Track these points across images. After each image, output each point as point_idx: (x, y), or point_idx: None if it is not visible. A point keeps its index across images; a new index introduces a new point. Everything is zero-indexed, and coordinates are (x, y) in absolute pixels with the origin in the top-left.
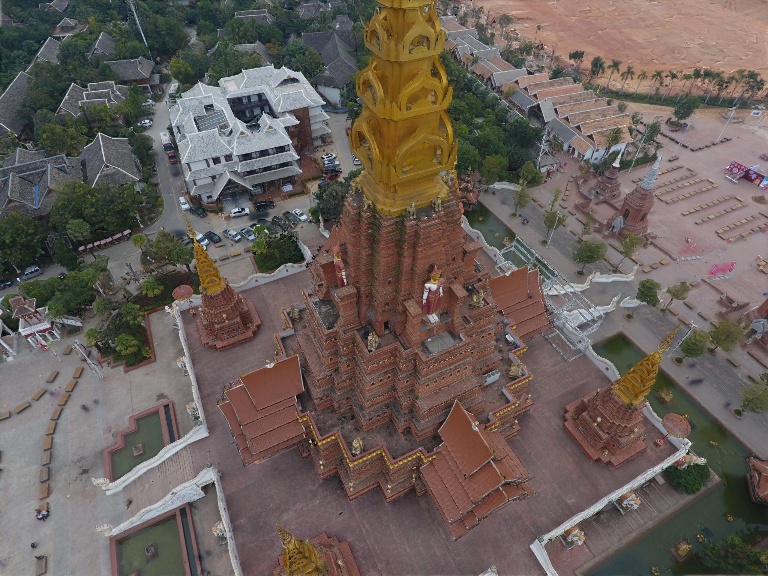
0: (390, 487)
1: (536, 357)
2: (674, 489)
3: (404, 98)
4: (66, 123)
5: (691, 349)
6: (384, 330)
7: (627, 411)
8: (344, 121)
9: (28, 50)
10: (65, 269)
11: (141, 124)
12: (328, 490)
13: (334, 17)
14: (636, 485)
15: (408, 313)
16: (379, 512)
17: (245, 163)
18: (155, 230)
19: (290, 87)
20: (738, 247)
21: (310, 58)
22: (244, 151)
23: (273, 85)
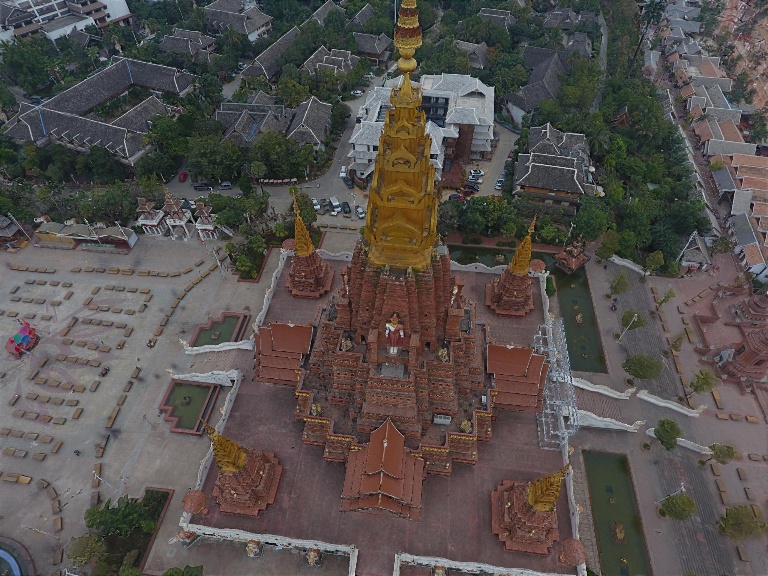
0: (327, 450)
1: (515, 428)
2: None
3: (385, 194)
4: (301, 78)
5: (670, 508)
6: (361, 341)
7: (529, 511)
8: None
9: (313, 6)
10: (242, 192)
11: (354, 93)
12: (295, 428)
13: (574, 32)
14: (517, 575)
15: None
16: (316, 463)
17: None
18: (313, 185)
19: (474, 100)
20: None
21: (514, 74)
22: None
23: (461, 94)
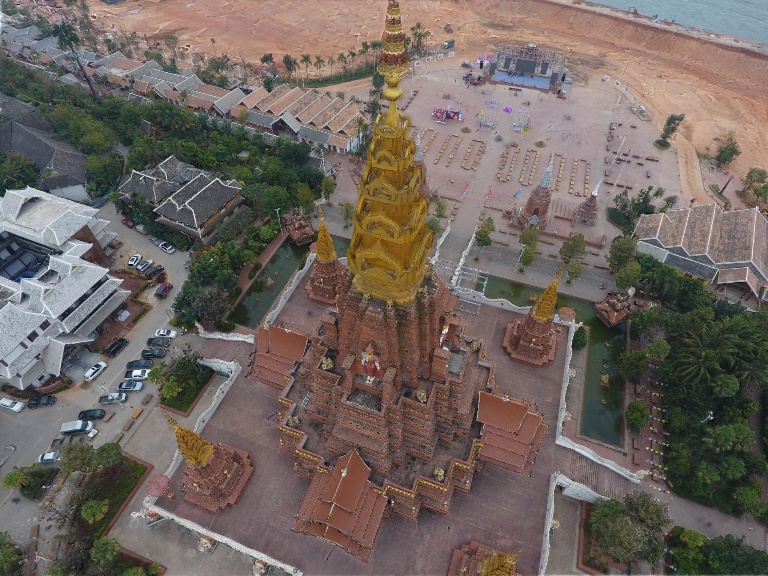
0: None
1: None
2: (577, 350)
3: (416, 223)
4: None
5: (528, 261)
6: None
7: (547, 325)
8: (110, 214)
9: None
10: None
11: None
12: (426, 522)
13: None
14: None
15: (436, 359)
16: (468, 504)
17: (68, 319)
18: (4, 455)
19: None
20: (480, 171)
21: (16, 164)
22: (63, 308)
23: (11, 217)
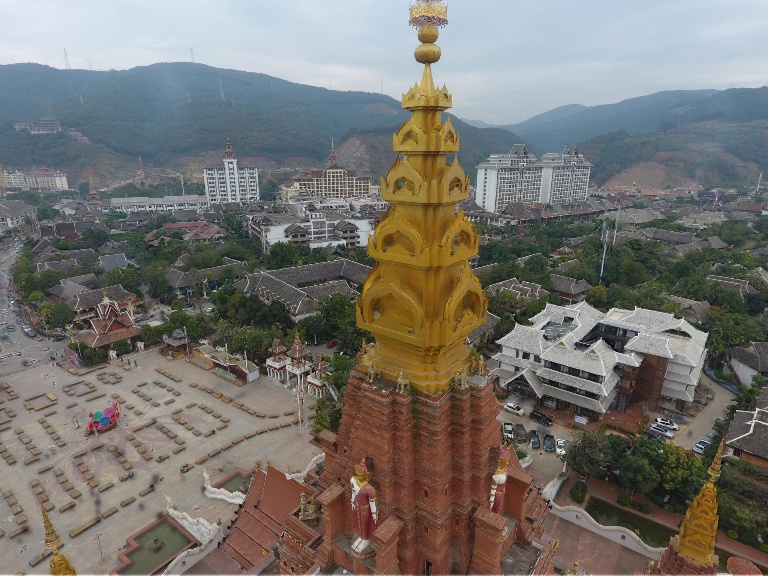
0: None
1: None
2: None
3: (379, 236)
4: None
5: None
6: None
7: None
8: None
9: None
10: None
11: None
12: None
13: None
14: None
15: None
16: None
17: (548, 370)
18: None
19: (674, 338)
20: None
21: (744, 329)
22: (551, 358)
23: (656, 330)
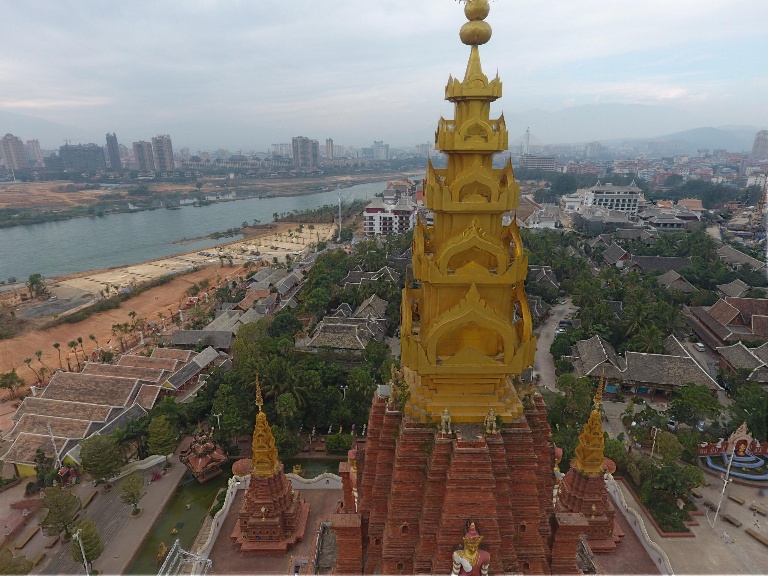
0: None
1: None
2: None
3: None
4: None
5: None
6: None
7: None
8: None
9: None
10: None
11: None
12: None
13: None
14: None
15: None
16: None
17: None
18: None
19: None
20: None
21: None
22: None
23: None
